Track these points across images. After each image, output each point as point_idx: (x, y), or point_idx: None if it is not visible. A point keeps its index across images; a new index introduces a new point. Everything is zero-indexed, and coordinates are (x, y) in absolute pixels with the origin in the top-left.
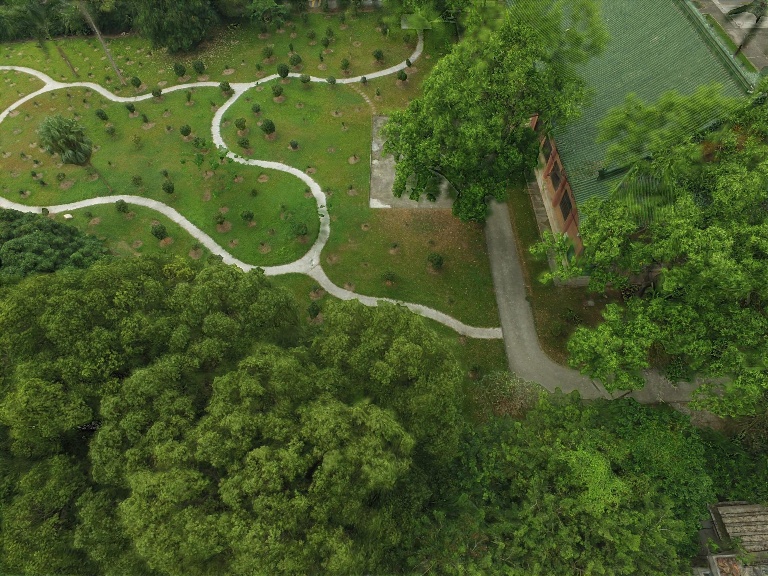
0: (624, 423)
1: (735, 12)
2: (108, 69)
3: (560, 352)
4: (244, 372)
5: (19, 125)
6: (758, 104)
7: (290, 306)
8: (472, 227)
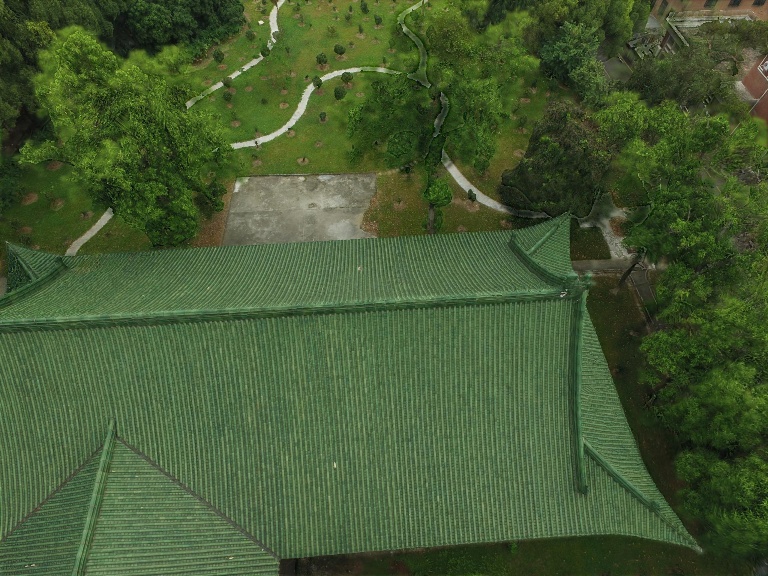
0: None
1: None
2: (449, 4)
3: None
4: None
5: None
6: None
7: None
8: None
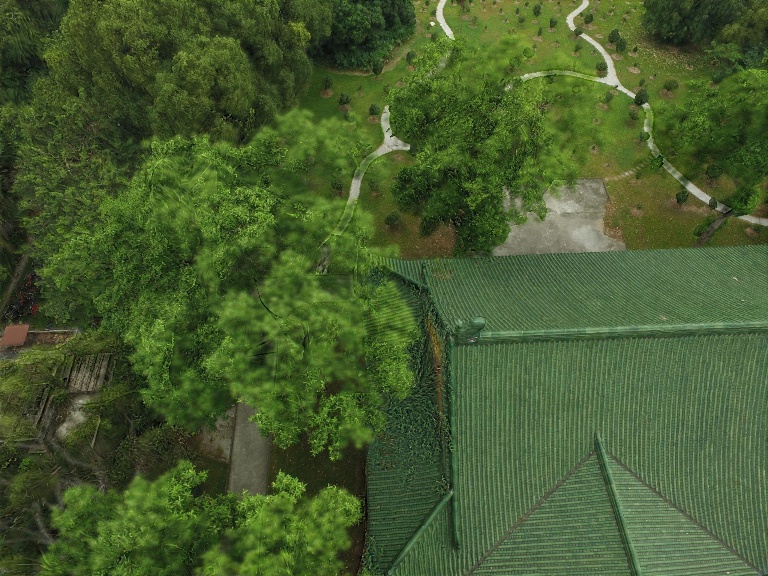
0: None
1: None
2: (611, 7)
3: (298, 318)
4: None
5: None
6: None
7: (265, 53)
8: None
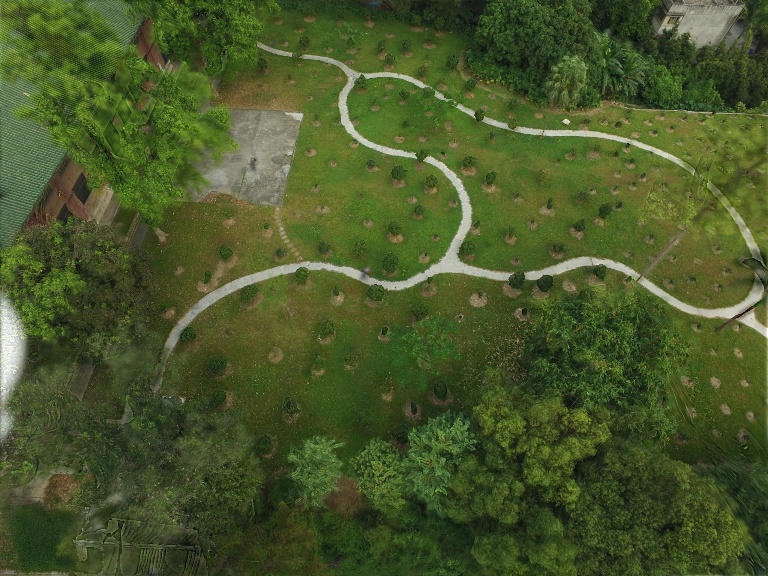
0: None
1: None
2: None
3: None
4: None
5: (719, 239)
6: None
7: None
8: (224, 93)
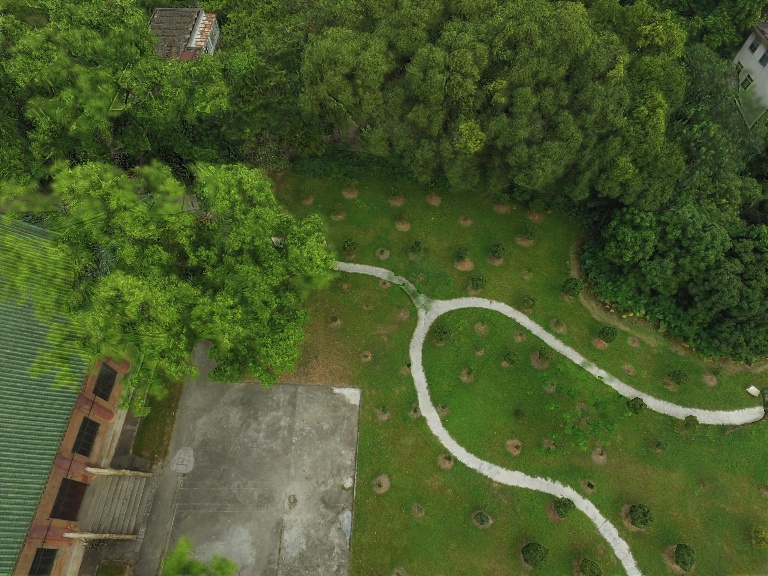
0: None
1: None
2: None
3: None
4: (422, 2)
5: None
6: None
7: None
8: None
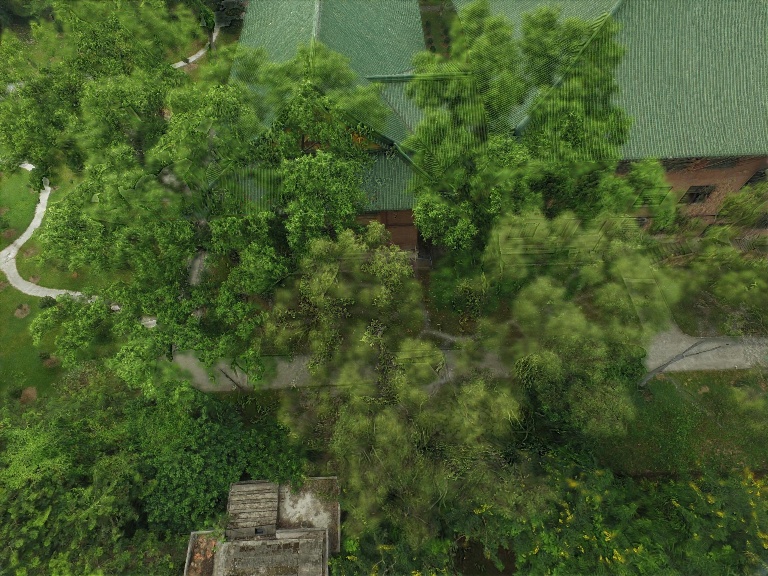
0: (131, 404)
1: (449, 4)
2: None
3: None
4: None
5: None
6: (310, 91)
7: None
8: None
